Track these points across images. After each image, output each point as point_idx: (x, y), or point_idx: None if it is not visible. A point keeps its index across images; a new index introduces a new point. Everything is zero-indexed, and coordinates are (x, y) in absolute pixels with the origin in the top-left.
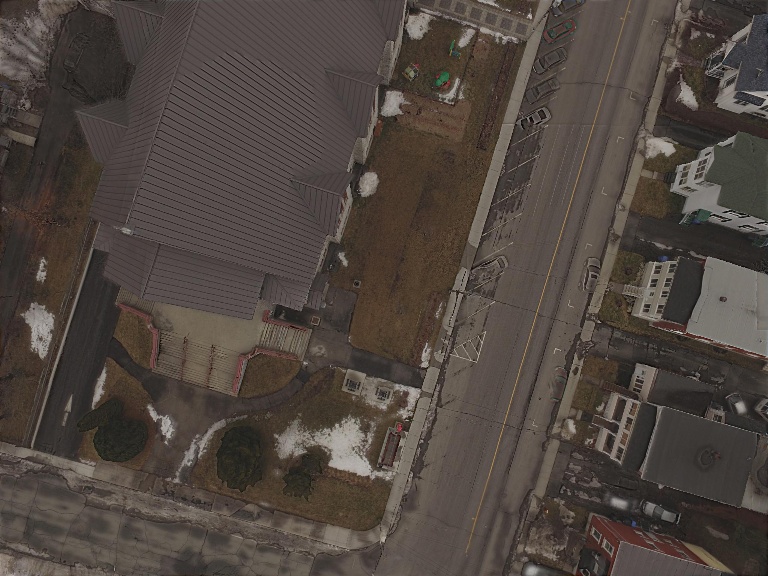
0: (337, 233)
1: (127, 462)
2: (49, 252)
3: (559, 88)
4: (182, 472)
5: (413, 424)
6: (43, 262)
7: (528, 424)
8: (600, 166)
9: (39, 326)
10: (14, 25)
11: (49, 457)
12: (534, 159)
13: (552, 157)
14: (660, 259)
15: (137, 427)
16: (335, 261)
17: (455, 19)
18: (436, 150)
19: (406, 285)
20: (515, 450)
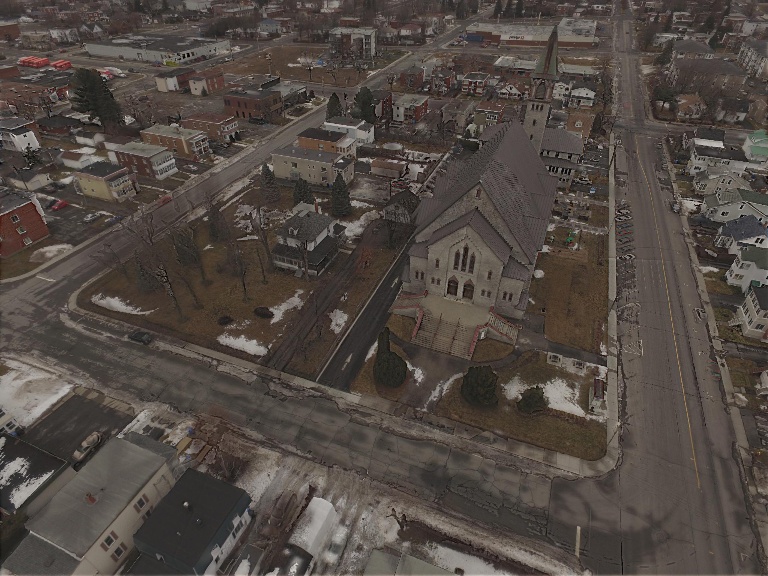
0: None
1: (387, 394)
2: (350, 290)
3: (634, 248)
4: (429, 405)
5: (609, 387)
6: (346, 294)
7: (704, 395)
8: (676, 275)
9: (337, 319)
10: (347, 223)
11: (327, 389)
12: (634, 270)
13: (645, 270)
14: None
15: None
16: None
17: (567, 227)
18: (574, 264)
19: (576, 314)
20: (703, 411)
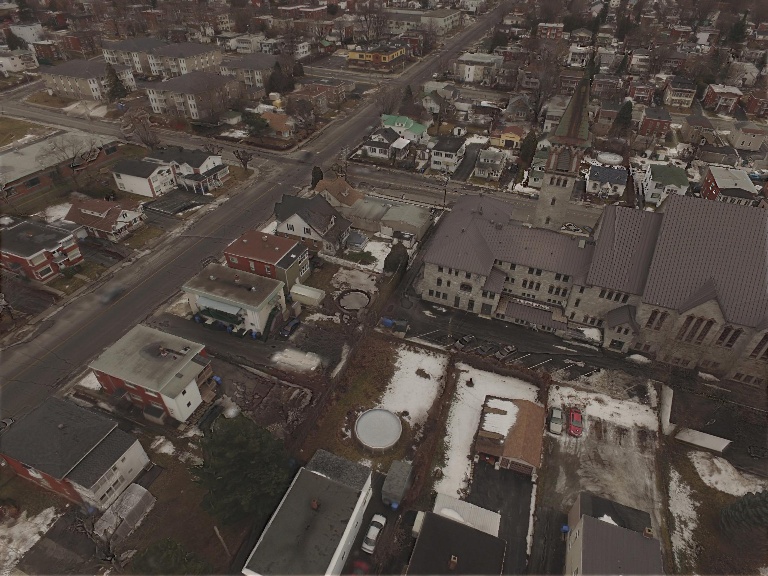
0: None
1: None
2: None
3: None
4: None
5: None
6: None
7: None
8: None
9: None
10: None
11: None
12: None
13: None
14: None
15: None
16: None
17: None
18: None
19: None
20: None
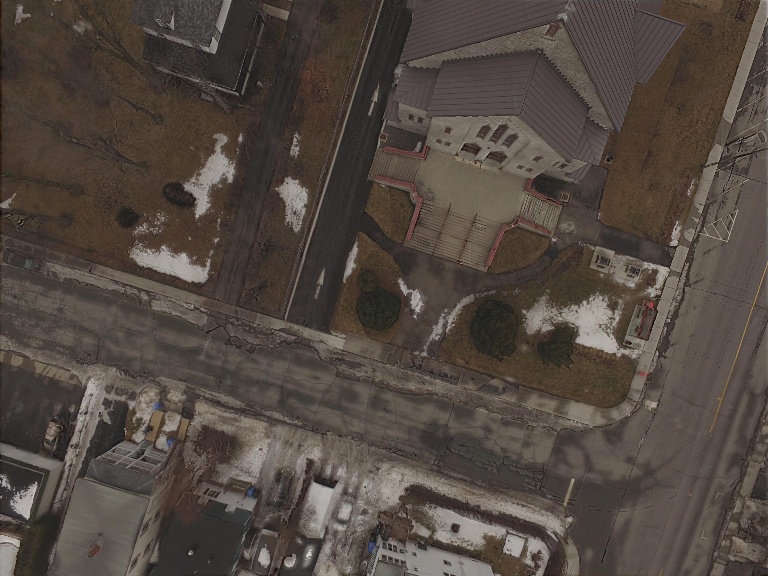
0: None
1: (377, 335)
2: (302, 127)
3: None
4: (430, 346)
5: (661, 303)
6: (296, 137)
7: None
8: None
9: (293, 200)
10: None
11: (301, 329)
12: None
13: None
14: None
15: (397, 296)
16: None
17: None
18: (693, 21)
19: (658, 161)
20: (764, 331)
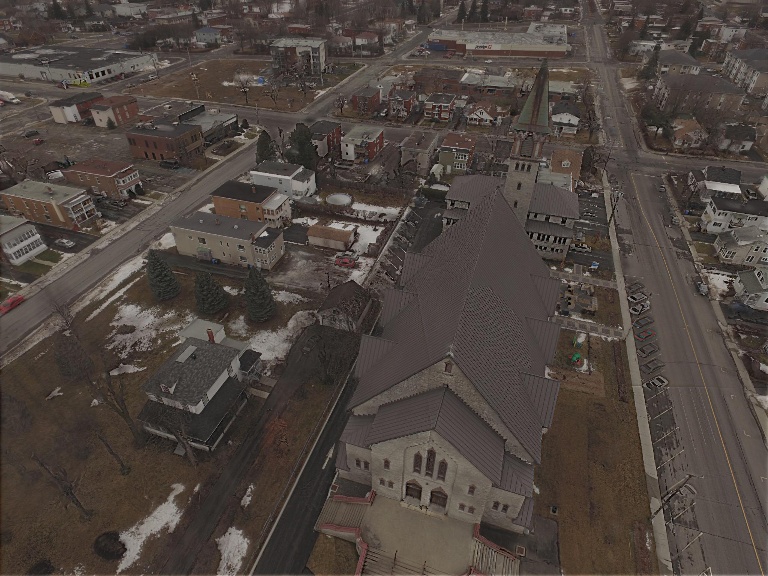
0: None
1: None
2: (259, 479)
3: (664, 365)
4: None
5: None
6: (251, 488)
7: None
8: (730, 415)
9: (230, 553)
10: (269, 333)
11: None
12: (671, 409)
13: (685, 408)
14: None
15: None
16: None
17: (569, 329)
18: (587, 402)
19: (603, 513)
20: None
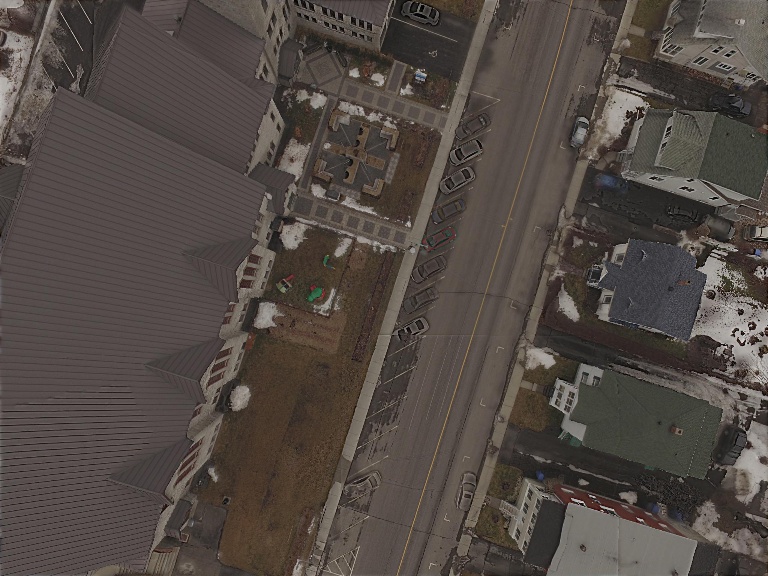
0: (192, 472)
1: None
2: None
3: (438, 298)
4: None
5: None
6: None
7: None
8: (479, 377)
9: None
10: None
11: None
12: (411, 370)
13: (429, 368)
14: (537, 476)
15: None
16: (204, 477)
17: (331, 228)
18: (310, 362)
19: (277, 501)
20: None
